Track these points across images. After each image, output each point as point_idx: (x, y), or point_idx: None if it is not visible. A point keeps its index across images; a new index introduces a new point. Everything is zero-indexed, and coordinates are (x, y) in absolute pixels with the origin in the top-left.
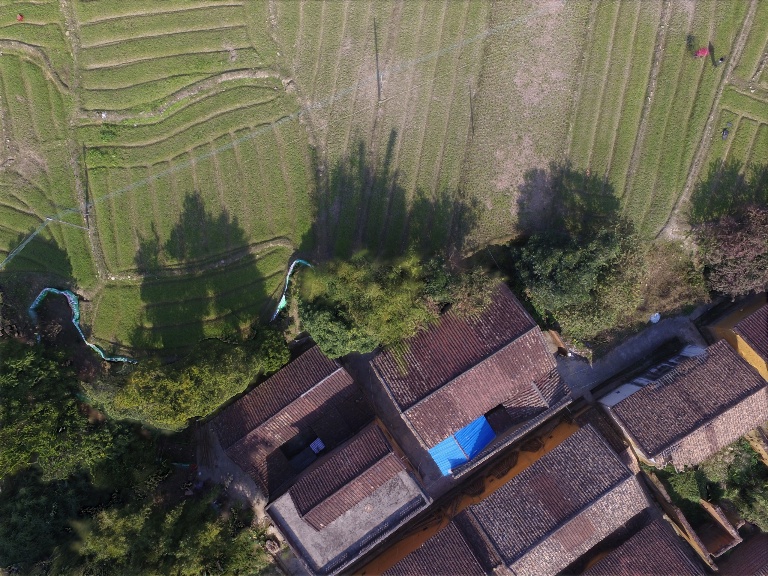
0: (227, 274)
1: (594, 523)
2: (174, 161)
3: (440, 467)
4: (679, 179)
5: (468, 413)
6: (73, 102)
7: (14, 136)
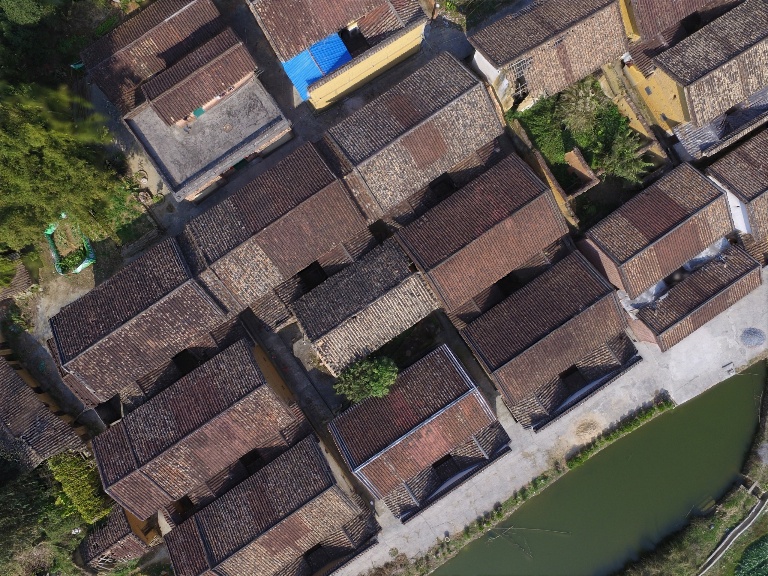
0: None
1: (445, 138)
2: None
3: (300, 92)
4: None
5: (322, 23)
6: None
7: None
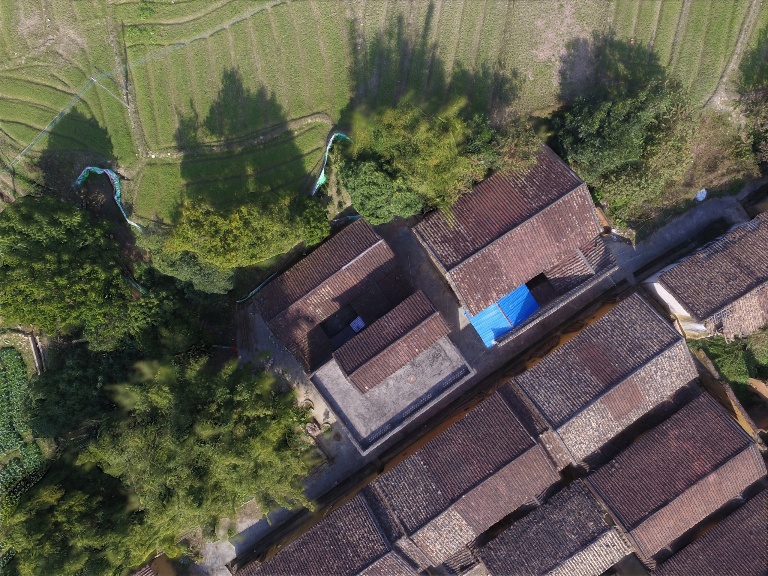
0: (266, 151)
1: (642, 390)
2: (212, 37)
3: (483, 338)
4: (728, 46)
5: (513, 278)
6: None
7: (54, 16)
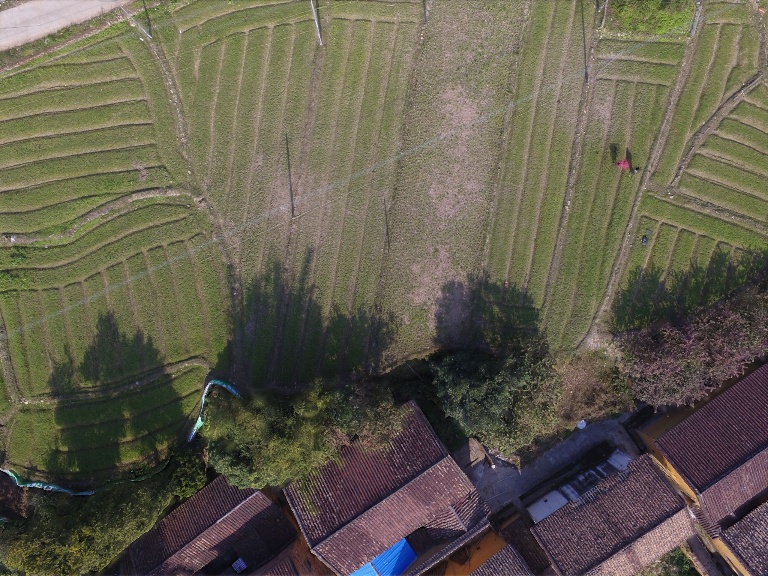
0: (143, 395)
1: None
2: (86, 282)
3: None
4: (599, 288)
5: (383, 541)
6: None
7: None
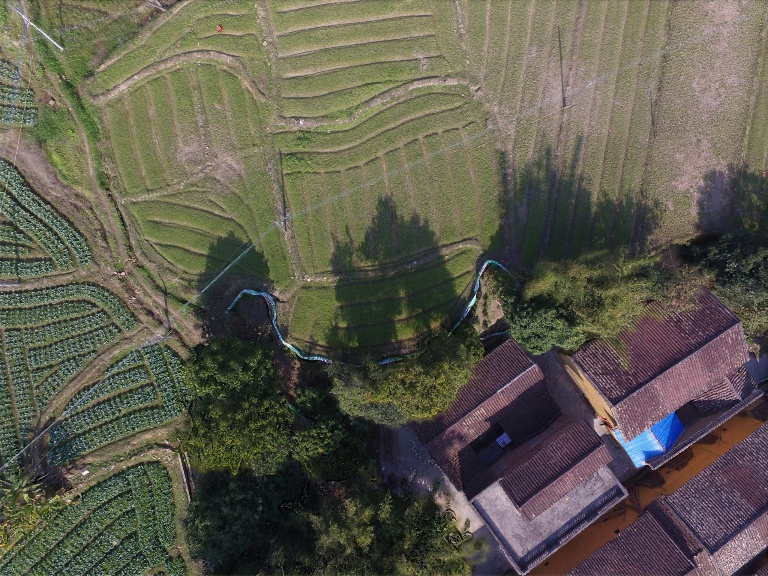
0: (418, 275)
1: None
2: (367, 166)
3: (633, 459)
4: None
5: (667, 406)
6: (270, 110)
7: (212, 143)
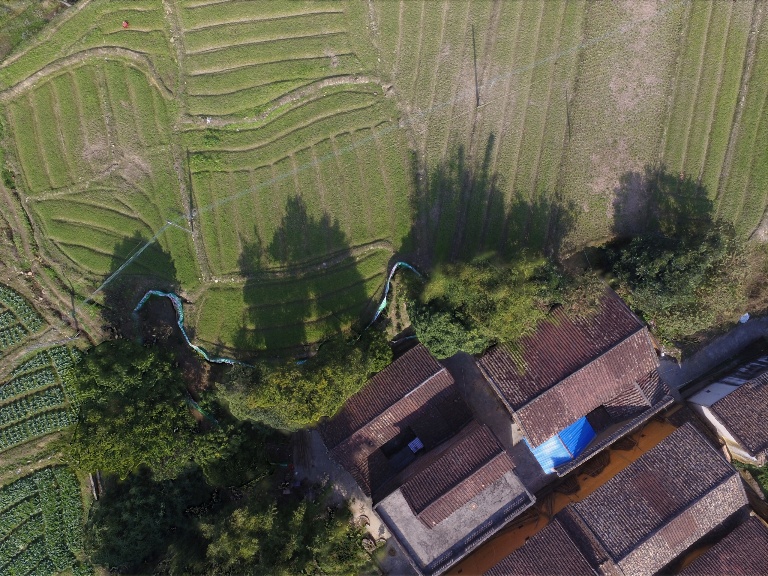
0: (328, 276)
1: (697, 520)
2: (276, 165)
3: (542, 466)
4: None
5: (574, 412)
6: (177, 107)
7: (118, 141)
